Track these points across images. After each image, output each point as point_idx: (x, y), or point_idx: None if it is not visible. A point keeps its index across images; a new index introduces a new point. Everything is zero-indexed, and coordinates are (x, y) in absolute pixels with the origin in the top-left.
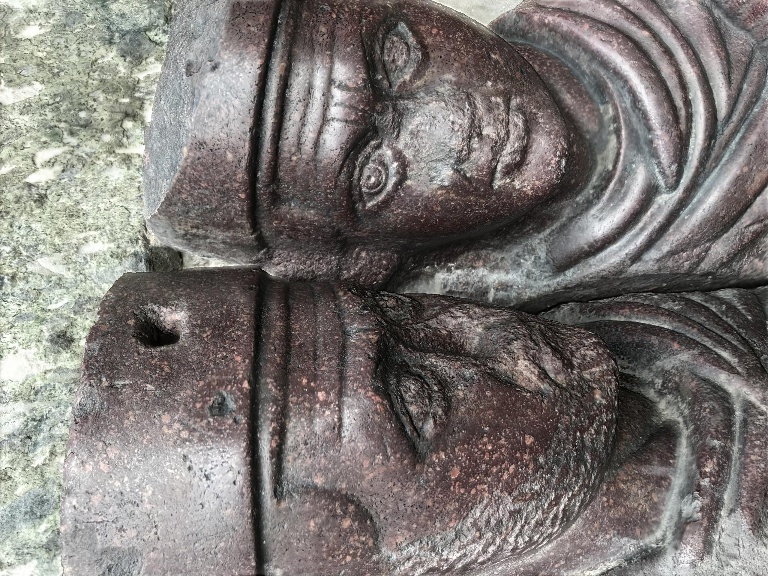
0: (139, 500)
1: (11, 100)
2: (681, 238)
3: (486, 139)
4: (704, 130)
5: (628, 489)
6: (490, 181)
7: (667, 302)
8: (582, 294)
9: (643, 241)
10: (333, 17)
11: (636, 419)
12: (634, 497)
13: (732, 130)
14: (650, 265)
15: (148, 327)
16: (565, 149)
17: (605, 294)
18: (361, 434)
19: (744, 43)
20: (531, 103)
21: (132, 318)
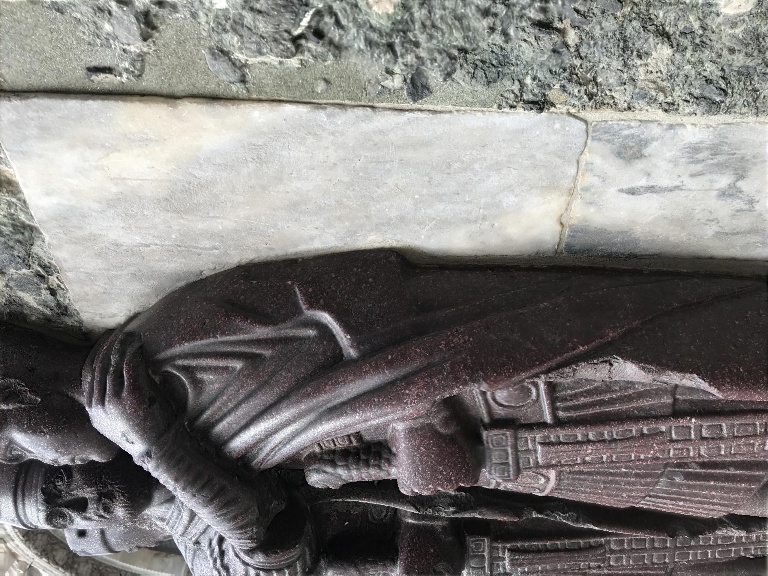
0: None
1: None
2: None
3: None
4: None
5: None
6: None
7: None
8: None
9: None
10: None
11: None
12: None
13: None
14: None
15: None
16: None
17: None
18: None
19: None
20: None
21: None
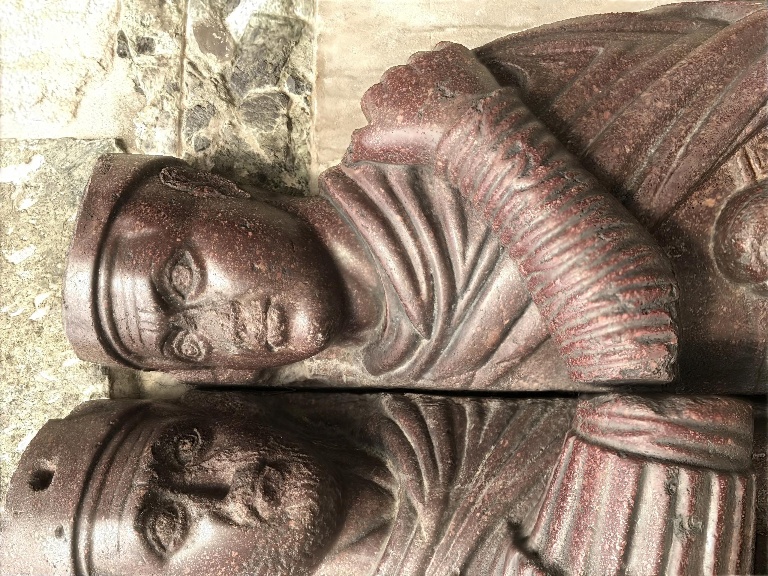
0: (28, 572)
1: (19, 260)
2: (444, 370)
3: (250, 332)
4: (443, 299)
5: (339, 569)
6: (268, 349)
7: (430, 419)
8: (402, 387)
9: (417, 369)
10: (133, 264)
11: (365, 518)
12: (342, 575)
13: (469, 296)
14: (430, 383)
15: (41, 472)
16: (318, 327)
17: (418, 389)
18: (128, 551)
19: (480, 223)
20: (289, 296)
21: (31, 469)
